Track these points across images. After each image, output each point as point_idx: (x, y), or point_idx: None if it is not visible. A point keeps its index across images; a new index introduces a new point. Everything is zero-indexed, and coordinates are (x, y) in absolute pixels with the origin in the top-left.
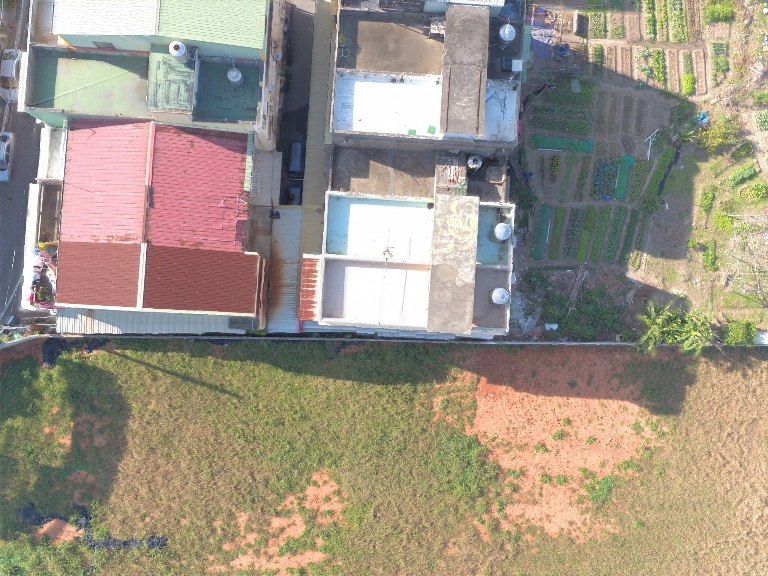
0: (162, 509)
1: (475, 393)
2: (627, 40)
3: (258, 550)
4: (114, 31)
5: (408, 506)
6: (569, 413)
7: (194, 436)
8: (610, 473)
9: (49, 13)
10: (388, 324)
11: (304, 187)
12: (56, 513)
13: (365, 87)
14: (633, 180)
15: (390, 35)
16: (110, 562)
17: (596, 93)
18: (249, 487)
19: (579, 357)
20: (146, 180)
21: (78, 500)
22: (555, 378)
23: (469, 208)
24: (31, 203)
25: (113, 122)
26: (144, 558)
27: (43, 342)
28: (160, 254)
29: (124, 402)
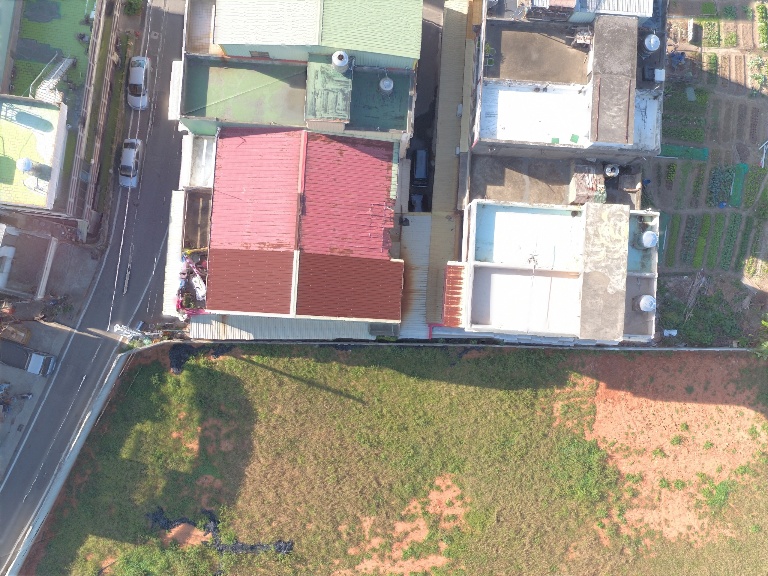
0: (289, 513)
1: (594, 398)
2: (740, 49)
3: (383, 554)
4: (275, 41)
5: (530, 511)
6: (686, 418)
7: (320, 441)
8: (727, 478)
9: (201, 22)
10: (536, 331)
11: (434, 194)
12: (184, 517)
13: (509, 96)
14: (748, 187)
15: (533, 45)
16: (238, 566)
17: (711, 101)
18: (374, 492)
19: (696, 363)
20: (299, 188)
21: (206, 505)
22: (672, 384)
23: (620, 216)
24: (174, 210)
25: (264, 130)
26: (271, 562)
27: (170, 347)
28: (312, 261)
29: (251, 407)
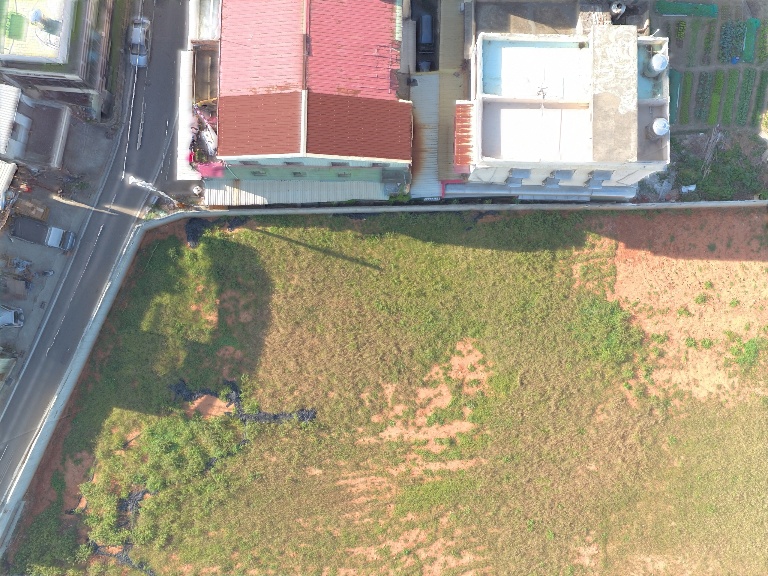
0: (310, 382)
1: (614, 259)
2: None
3: (406, 421)
4: None
5: (554, 372)
6: (710, 276)
7: (338, 309)
8: (756, 335)
9: None
10: (548, 160)
11: (441, 52)
12: (206, 389)
13: None
14: (761, 41)
15: None
16: (261, 436)
17: None
18: (394, 358)
19: (717, 220)
20: (304, 29)
21: (227, 376)
22: (694, 241)
23: (627, 37)
24: (184, 70)
25: None
26: (295, 431)
27: (186, 223)
28: (320, 101)
29: (268, 278)
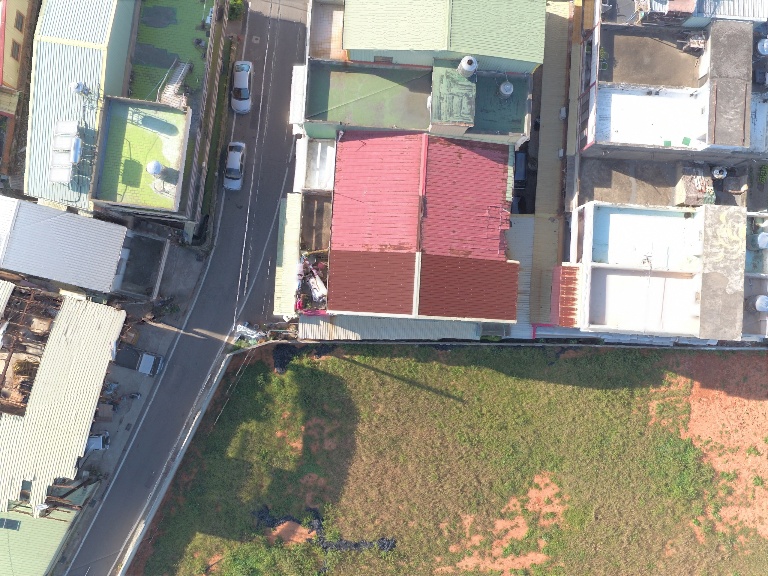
0: (391, 511)
1: (689, 397)
2: None
3: (483, 552)
4: (402, 46)
5: (628, 508)
6: None
7: (421, 440)
8: None
9: (322, 28)
10: (652, 331)
11: (537, 196)
12: (289, 515)
13: (622, 99)
14: None
15: (645, 49)
16: (342, 563)
17: None
18: (474, 490)
19: None
20: (420, 190)
21: (310, 503)
22: (765, 383)
23: (738, 218)
24: (290, 212)
25: (384, 134)
26: (375, 559)
27: (273, 348)
28: (433, 263)
29: (353, 406)
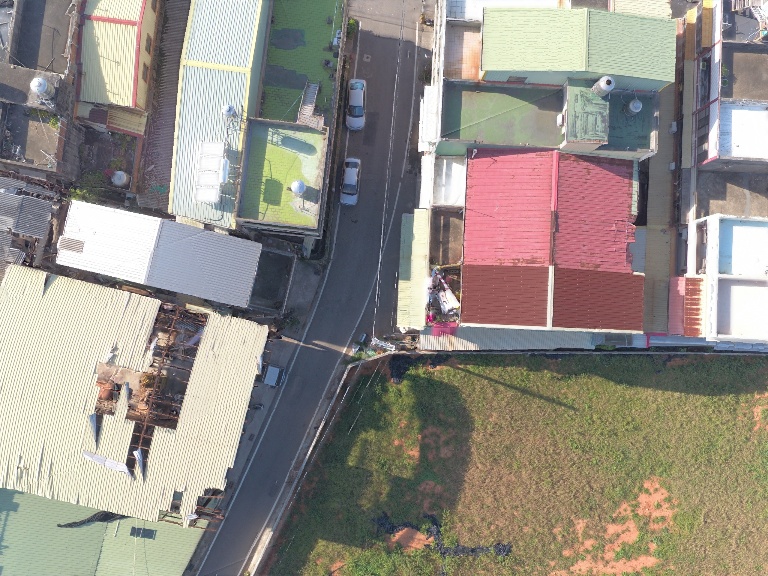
0: (507, 517)
1: None
2: None
3: (596, 556)
4: (540, 67)
5: (735, 512)
6: None
7: (534, 447)
8: None
9: (453, 49)
10: None
11: (648, 208)
12: (408, 522)
13: (742, 115)
14: None
15: (763, 65)
16: (460, 568)
17: None
18: (587, 495)
19: None
20: (552, 206)
21: (428, 509)
22: None
23: None
24: (417, 228)
25: (515, 151)
26: (492, 564)
27: (389, 358)
28: (565, 276)
29: (468, 415)
